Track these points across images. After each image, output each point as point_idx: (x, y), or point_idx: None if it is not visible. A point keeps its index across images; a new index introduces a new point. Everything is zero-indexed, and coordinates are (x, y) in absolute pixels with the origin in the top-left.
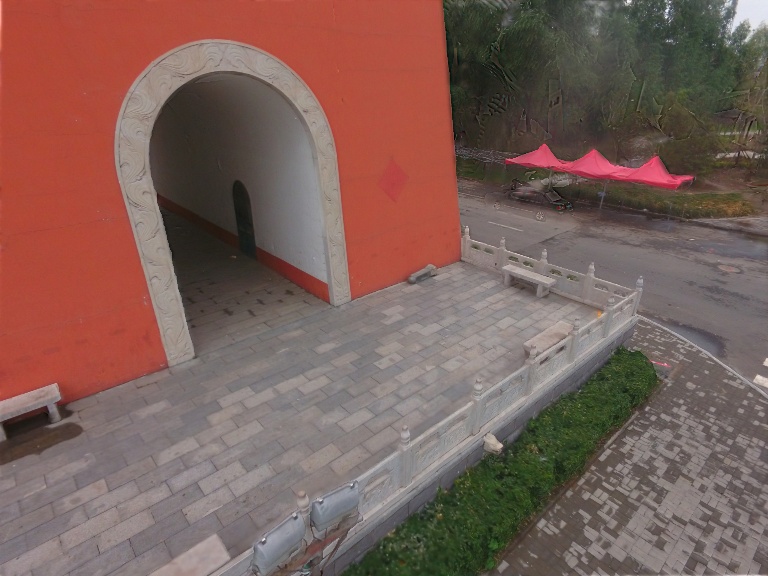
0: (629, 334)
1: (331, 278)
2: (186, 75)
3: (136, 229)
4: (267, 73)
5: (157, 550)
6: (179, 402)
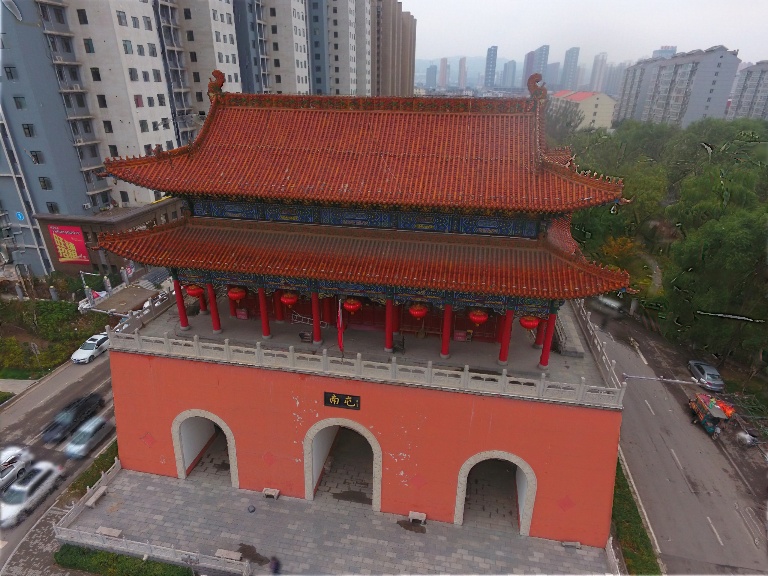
0: None
1: (521, 525)
2: (486, 458)
3: (458, 488)
4: (514, 461)
5: None
6: (449, 541)
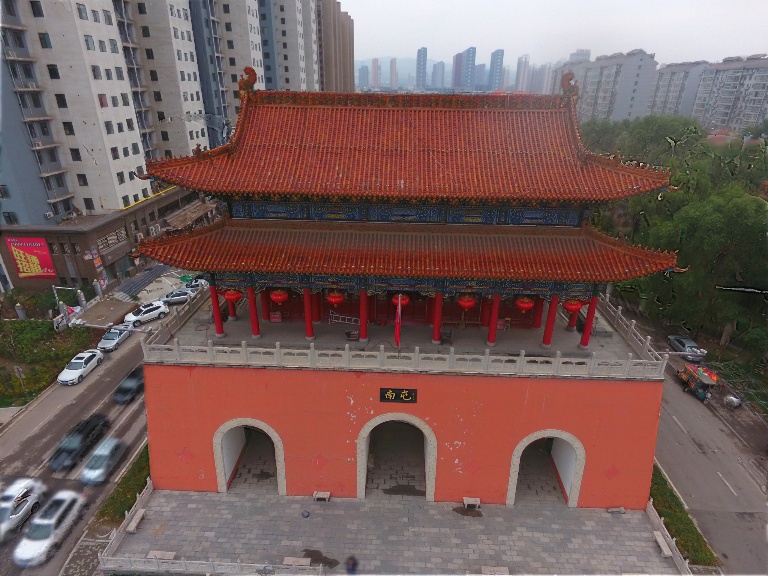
0: None
1: (570, 497)
2: (539, 437)
3: (511, 469)
4: (565, 437)
5: (495, 561)
6: (506, 521)
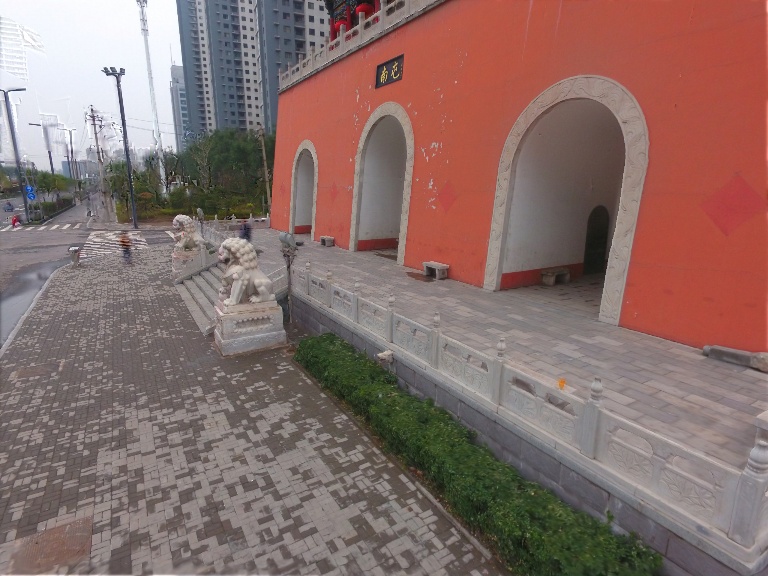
0: (700, 566)
1: None
2: None
3: (496, 199)
4: (599, 94)
5: None
6: (448, 291)
